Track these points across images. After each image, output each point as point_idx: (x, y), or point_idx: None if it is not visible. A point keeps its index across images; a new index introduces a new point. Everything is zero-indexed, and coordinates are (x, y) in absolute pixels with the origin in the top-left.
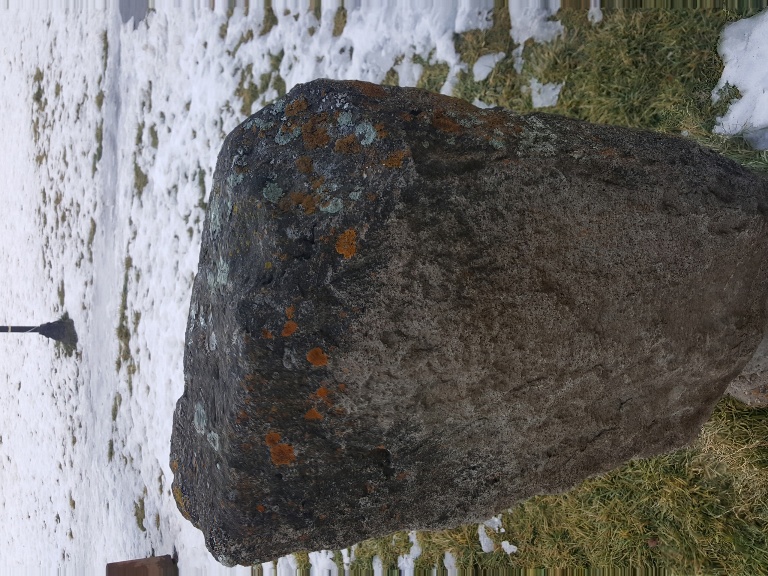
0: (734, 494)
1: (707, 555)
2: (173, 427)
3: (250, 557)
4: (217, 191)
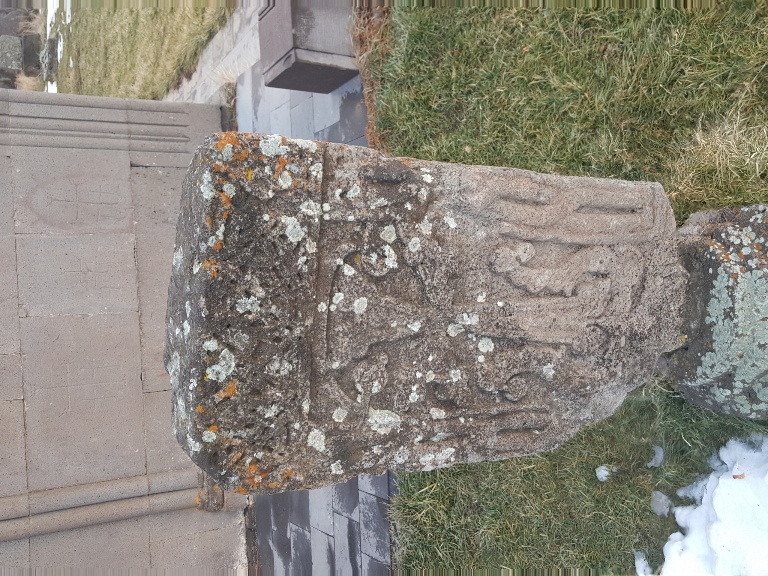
0: (762, 97)
1: (764, 21)
2: (202, 208)
3: None
4: None
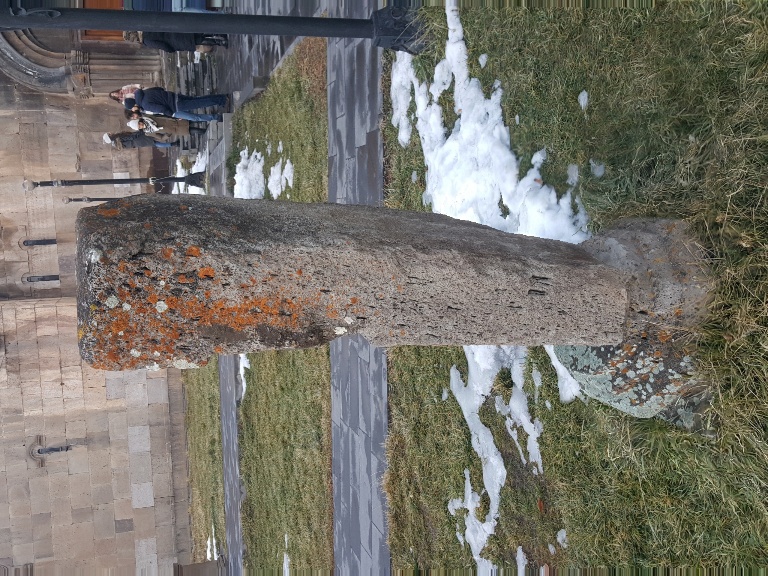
0: None
1: None
2: None
3: (109, 241)
4: None
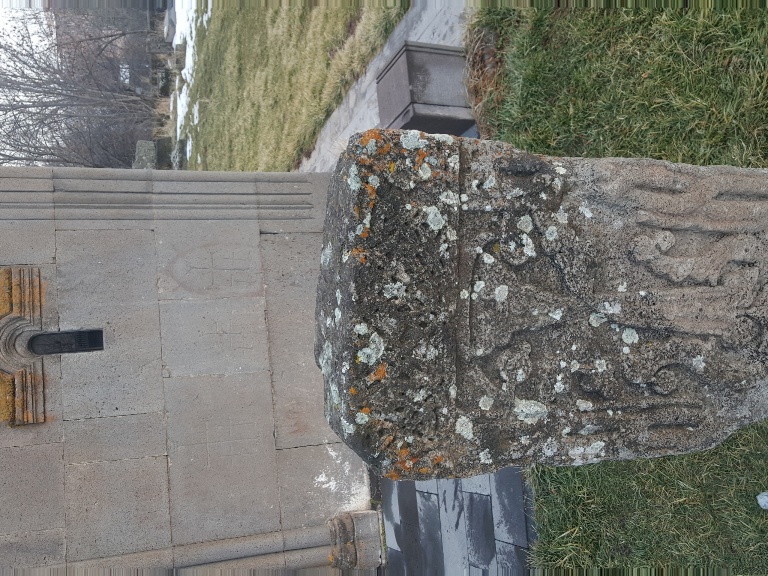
0: None
1: None
2: (349, 199)
3: None
4: (340, 405)
